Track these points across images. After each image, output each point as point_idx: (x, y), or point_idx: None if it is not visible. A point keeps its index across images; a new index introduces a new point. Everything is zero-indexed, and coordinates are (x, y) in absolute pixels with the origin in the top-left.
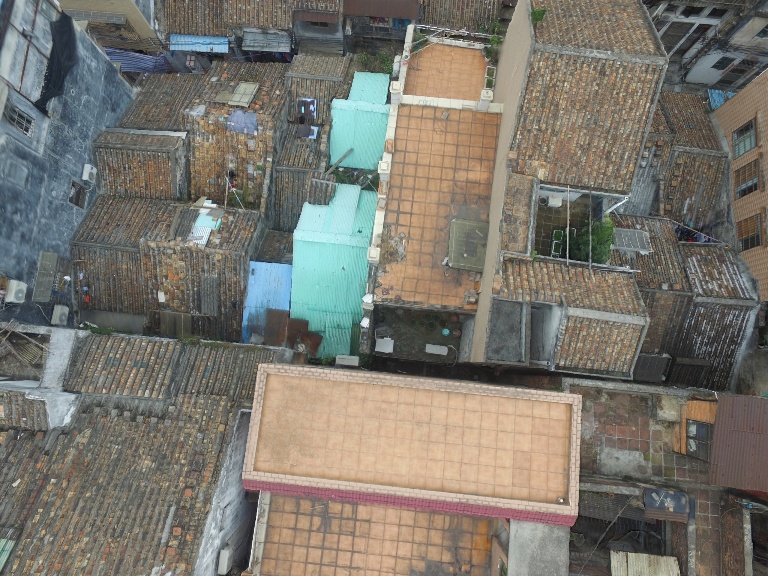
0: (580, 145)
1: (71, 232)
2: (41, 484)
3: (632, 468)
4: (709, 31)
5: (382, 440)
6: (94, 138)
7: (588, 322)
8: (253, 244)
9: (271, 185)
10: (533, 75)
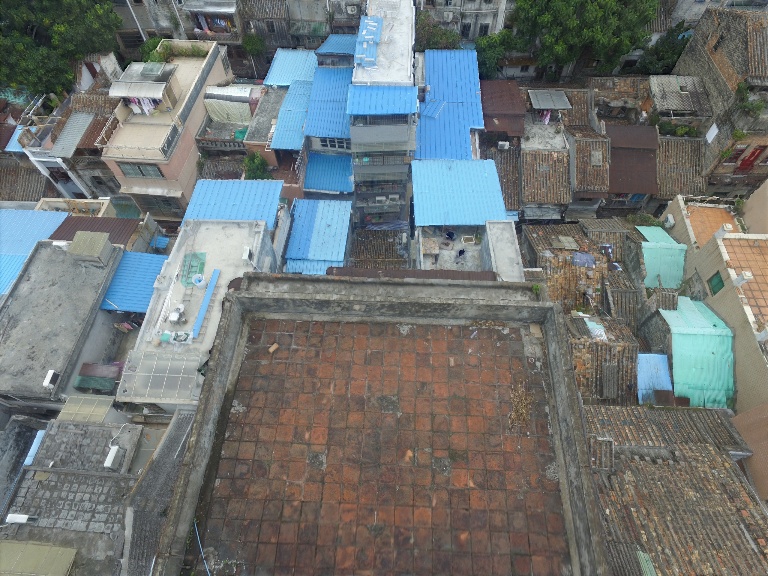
0: None
1: None
2: (626, 512)
3: None
4: None
5: None
6: None
7: None
8: None
9: None
10: None
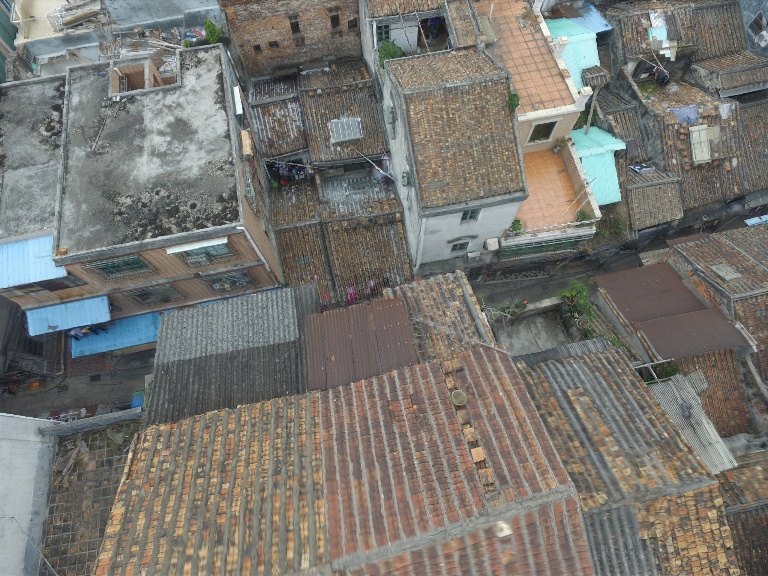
0: None
1: (743, 6)
2: None
3: None
4: None
5: None
6: None
7: None
8: None
9: None
10: None
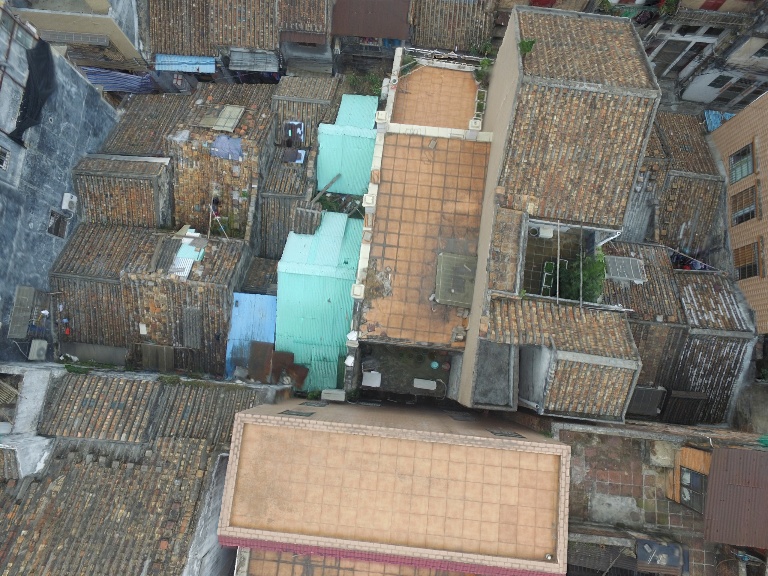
0: (570, 179)
1: (50, 263)
2: (11, 536)
3: (624, 515)
4: (706, 49)
5: (363, 493)
6: (75, 165)
7: (578, 366)
8: (237, 275)
9: (256, 212)
10: (521, 108)
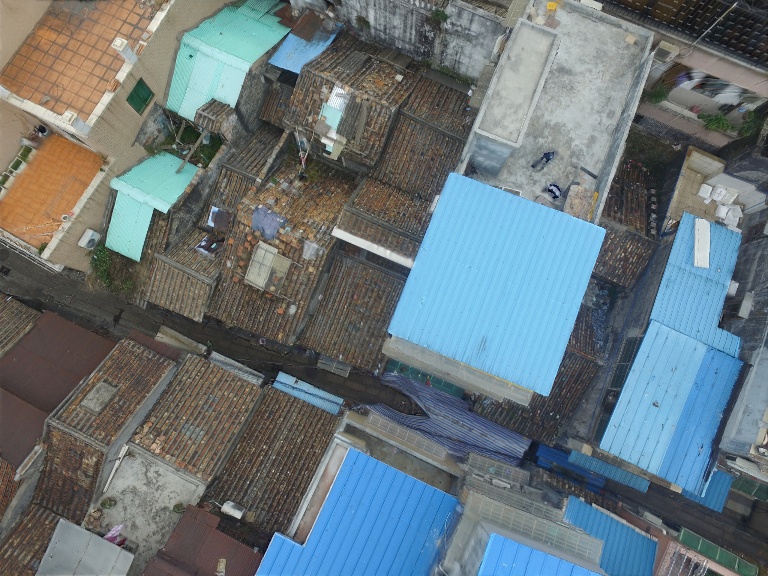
0: None
1: None
2: None
3: None
4: None
5: None
6: None
7: None
8: None
9: None
10: None
